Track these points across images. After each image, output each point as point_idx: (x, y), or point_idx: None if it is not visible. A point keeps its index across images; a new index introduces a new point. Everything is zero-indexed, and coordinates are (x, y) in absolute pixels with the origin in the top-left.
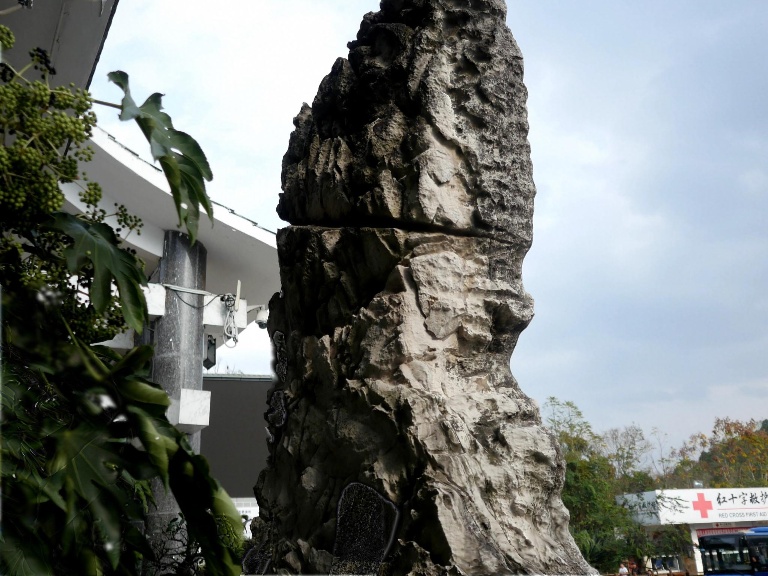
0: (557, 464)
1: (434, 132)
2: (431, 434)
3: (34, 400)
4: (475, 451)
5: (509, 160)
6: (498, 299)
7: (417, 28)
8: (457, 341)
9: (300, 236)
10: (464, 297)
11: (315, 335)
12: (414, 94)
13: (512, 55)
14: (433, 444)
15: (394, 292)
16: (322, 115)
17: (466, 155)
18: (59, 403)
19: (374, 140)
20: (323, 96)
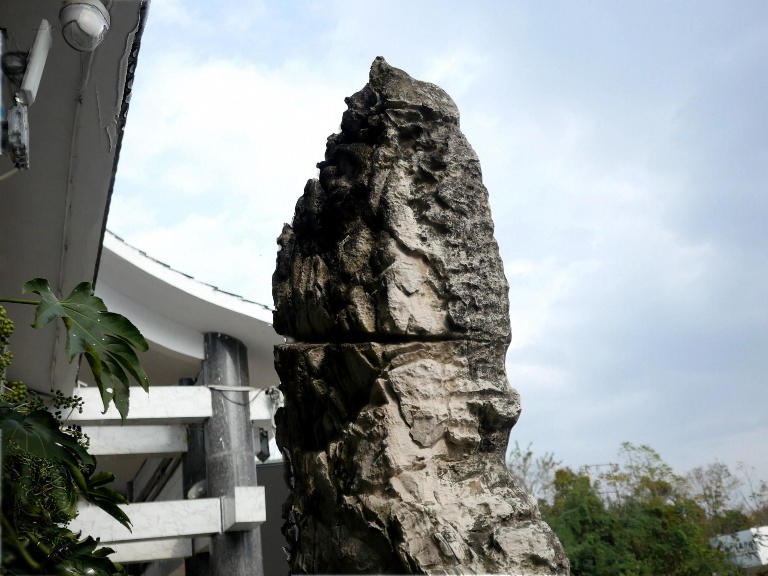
0: (557, 564)
1: (398, 245)
2: (423, 549)
3: (45, 553)
4: (470, 560)
5: (476, 260)
6: (481, 399)
7: (374, 146)
8: (446, 446)
9: (290, 356)
10: (447, 402)
11: (314, 452)
12: (377, 210)
13: (467, 159)
14: (426, 559)
15: (378, 405)
16: (302, 234)
17: (432, 262)
18: (72, 551)
19: (345, 258)
20: (301, 216)
